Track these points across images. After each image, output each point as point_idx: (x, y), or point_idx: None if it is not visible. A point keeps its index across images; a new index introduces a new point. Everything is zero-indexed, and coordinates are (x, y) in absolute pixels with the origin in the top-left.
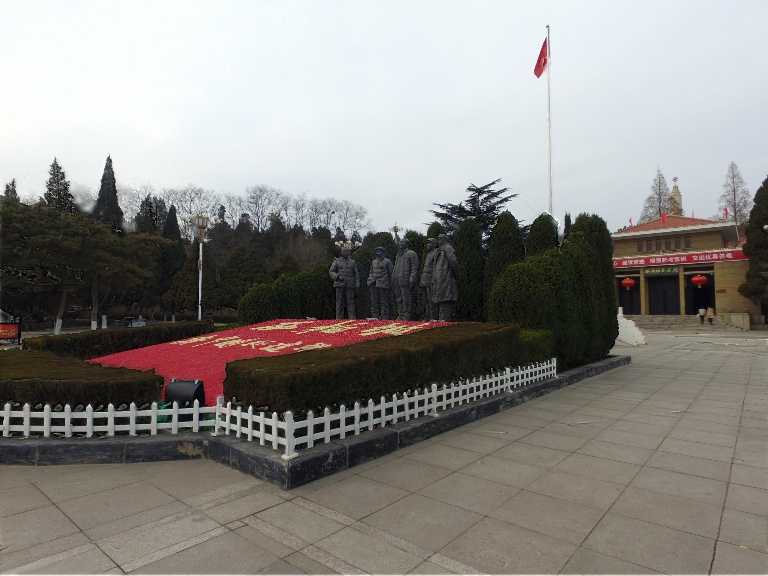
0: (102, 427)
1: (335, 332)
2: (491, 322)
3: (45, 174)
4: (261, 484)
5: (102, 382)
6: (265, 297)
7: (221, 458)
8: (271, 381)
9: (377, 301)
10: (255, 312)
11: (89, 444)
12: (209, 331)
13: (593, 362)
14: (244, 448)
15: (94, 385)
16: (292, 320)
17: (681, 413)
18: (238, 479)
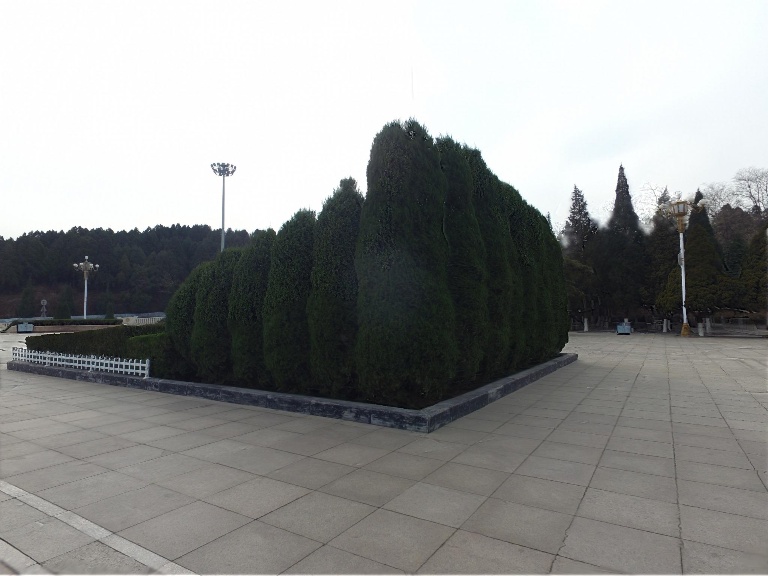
0: None
1: None
2: None
3: (569, 201)
4: None
5: None
6: None
7: None
8: None
9: None
10: None
11: None
12: None
13: (278, 391)
14: None
15: None
16: None
17: None
18: None
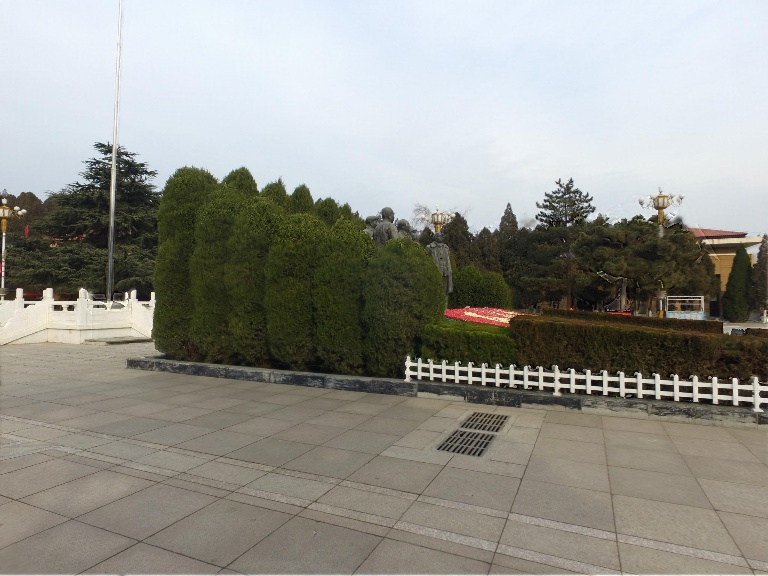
0: None
1: None
2: None
3: None
4: None
5: None
6: None
7: None
8: None
9: None
10: None
11: None
12: None
13: None
14: None
15: None
16: (447, 311)
17: None
18: None
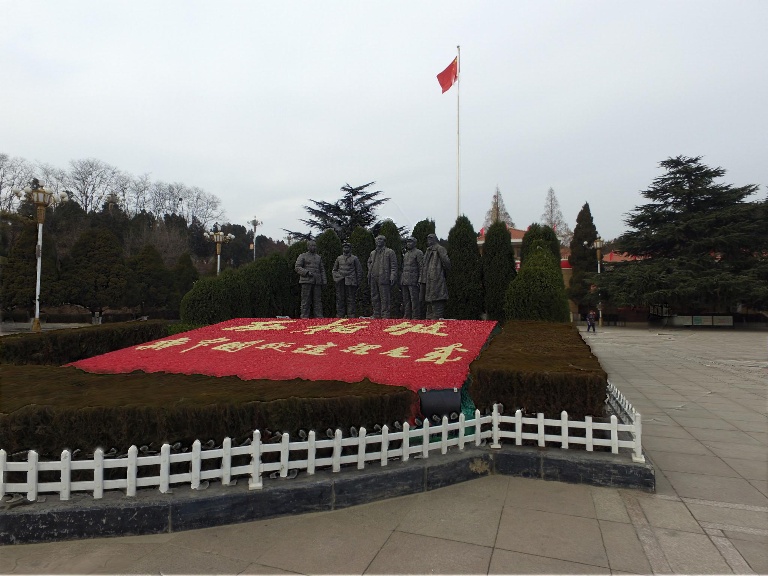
0: (396, 451)
1: (353, 332)
2: (513, 320)
3: None
4: (618, 491)
5: (378, 397)
6: (219, 293)
7: (522, 471)
8: (578, 384)
9: (343, 299)
10: (209, 310)
11: (390, 474)
12: (164, 333)
13: None
14: (566, 457)
15: (371, 401)
16: (260, 319)
17: (715, 393)
18: (584, 490)
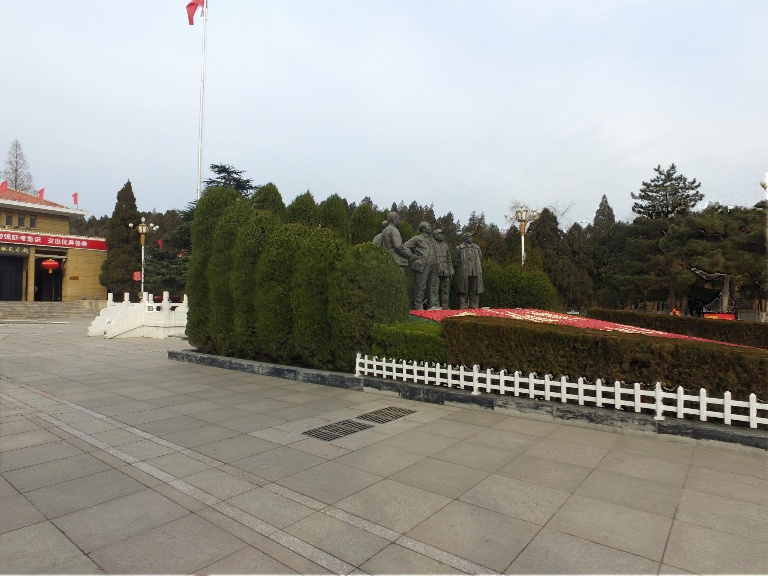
0: None
1: (559, 320)
2: None
3: None
4: None
5: None
6: None
7: None
8: None
9: None
10: None
11: None
12: None
13: None
14: None
15: None
16: None
17: None
18: None
